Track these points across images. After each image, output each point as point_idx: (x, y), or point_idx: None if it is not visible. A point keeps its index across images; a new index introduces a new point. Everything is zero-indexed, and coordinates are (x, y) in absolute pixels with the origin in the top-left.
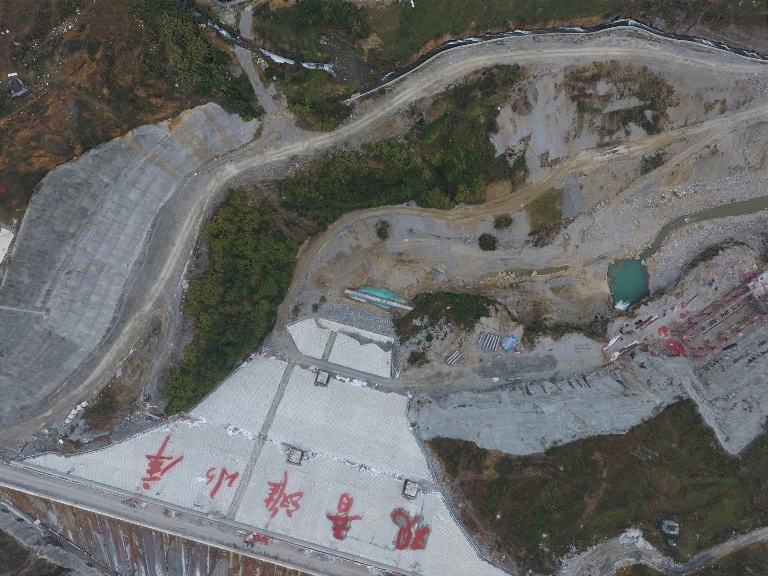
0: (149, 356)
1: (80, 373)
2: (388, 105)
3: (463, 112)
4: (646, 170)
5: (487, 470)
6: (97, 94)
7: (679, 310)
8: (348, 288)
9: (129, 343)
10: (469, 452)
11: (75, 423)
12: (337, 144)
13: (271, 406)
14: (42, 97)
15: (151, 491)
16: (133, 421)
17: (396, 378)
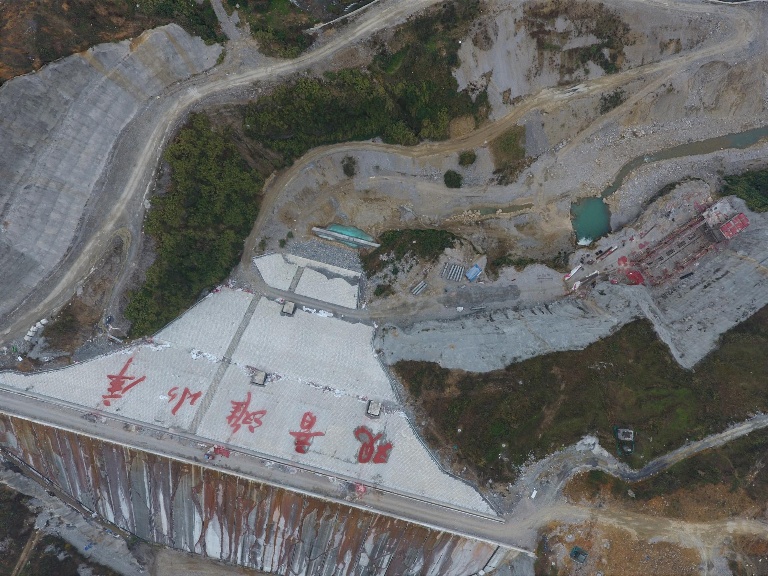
0: (111, 276)
1: (40, 291)
2: (350, 35)
3: (425, 45)
4: (605, 109)
5: (449, 388)
6: (57, 10)
7: (638, 241)
8: (316, 226)
9: (90, 262)
10: (432, 372)
11: (34, 340)
12: (300, 71)
13: (236, 333)
14: (1, 11)
15: (112, 407)
16: (95, 343)
17: (362, 309)
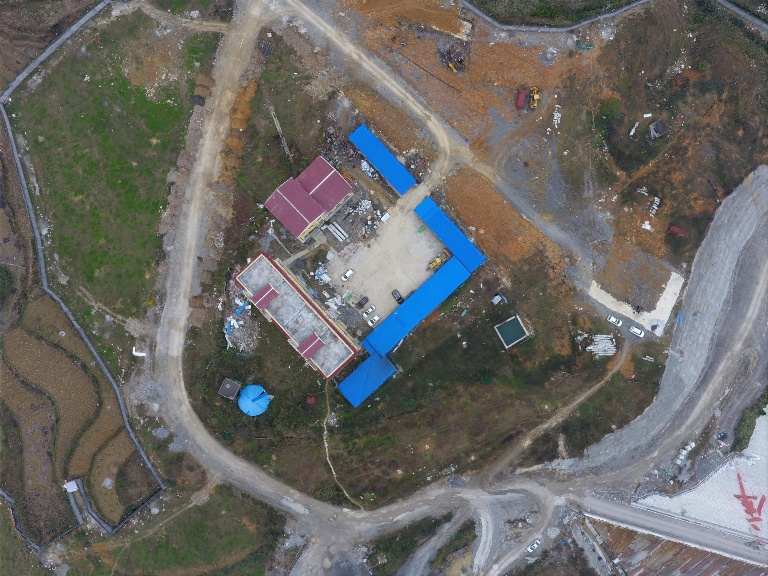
0: None
1: (682, 413)
2: None
3: None
4: None
5: None
6: (729, 135)
7: None
8: None
9: (724, 383)
10: None
11: (683, 464)
12: None
13: None
14: (679, 138)
15: (763, 532)
16: (706, 459)
17: None
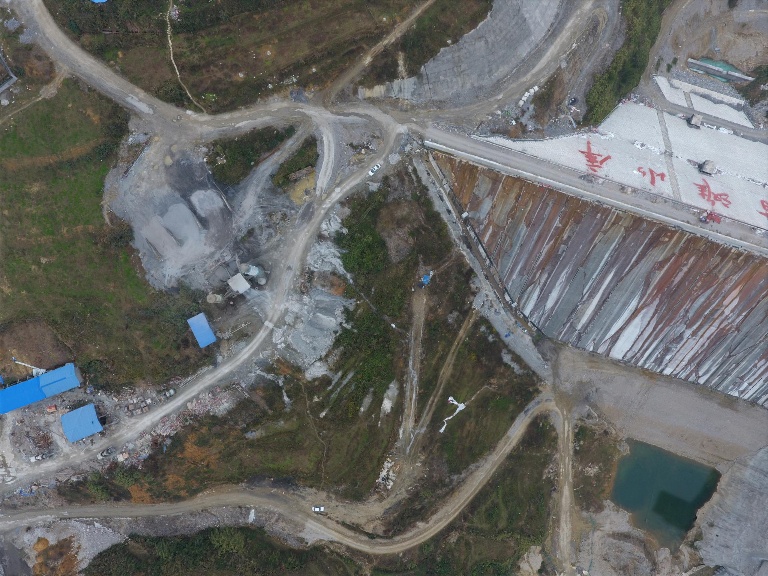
0: (582, 57)
1: (528, 62)
2: None
3: None
4: None
5: None
6: None
7: None
8: (691, 57)
9: (572, 38)
10: None
11: (526, 107)
12: None
13: (662, 134)
14: None
15: (600, 173)
16: (557, 124)
17: (761, 129)
